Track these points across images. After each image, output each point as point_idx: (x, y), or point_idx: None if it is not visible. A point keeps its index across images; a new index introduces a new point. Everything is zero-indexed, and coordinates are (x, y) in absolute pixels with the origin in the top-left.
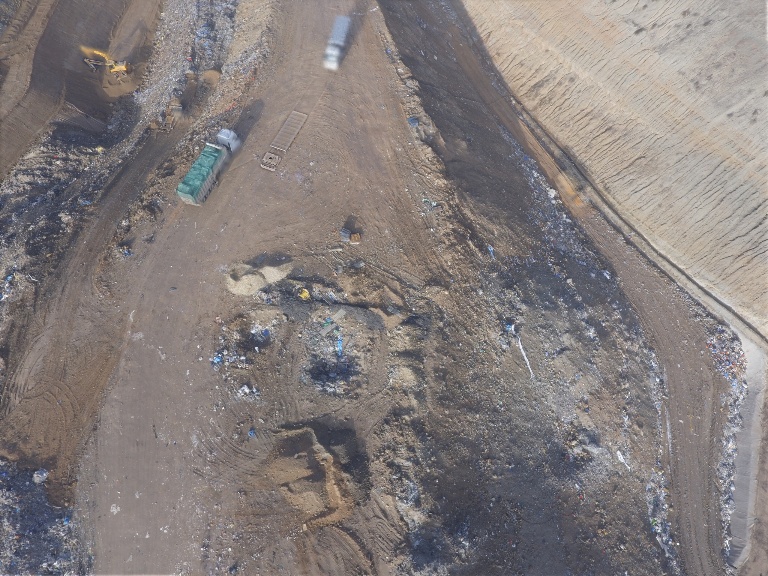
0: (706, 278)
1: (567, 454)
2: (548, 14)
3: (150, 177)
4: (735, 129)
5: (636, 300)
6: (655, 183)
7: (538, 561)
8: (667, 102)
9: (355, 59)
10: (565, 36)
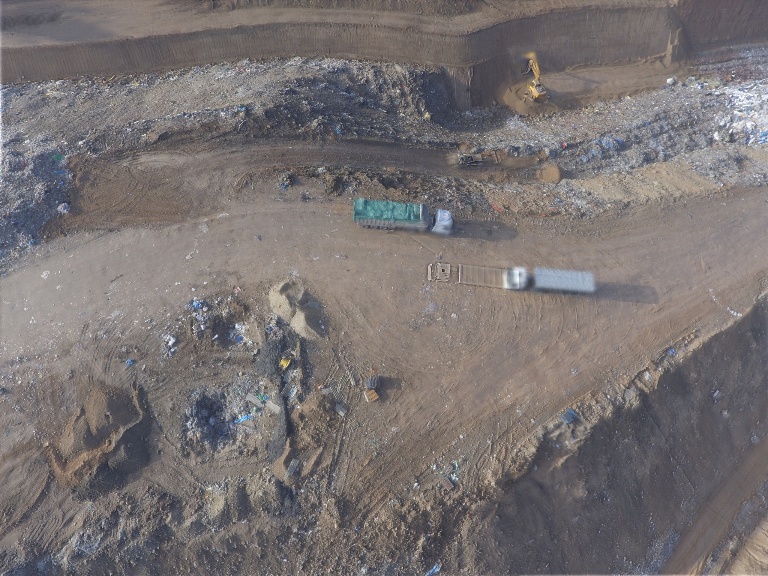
0: None
1: None
2: None
3: (390, 169)
4: None
5: None
6: None
7: None
8: None
9: (634, 314)
10: None
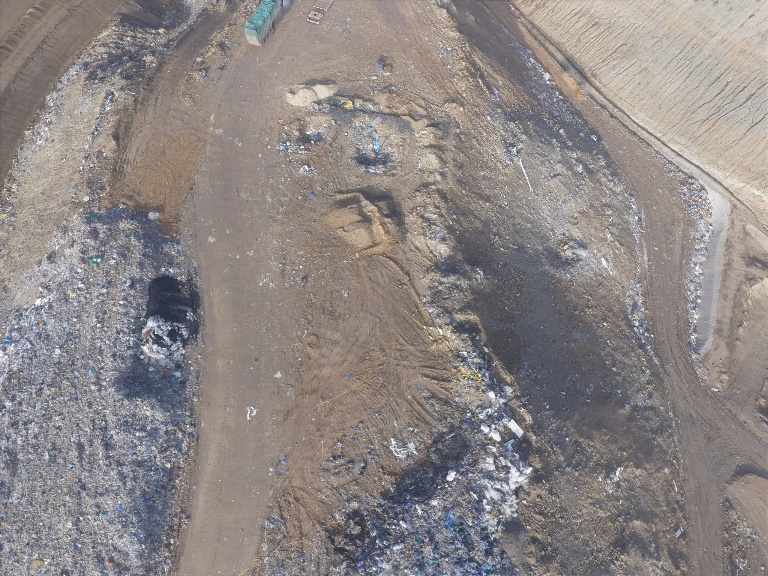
0: (678, 142)
1: (560, 256)
2: None
3: (214, 35)
4: (701, 11)
5: (619, 159)
6: (635, 65)
7: (537, 311)
8: None
9: None
10: None
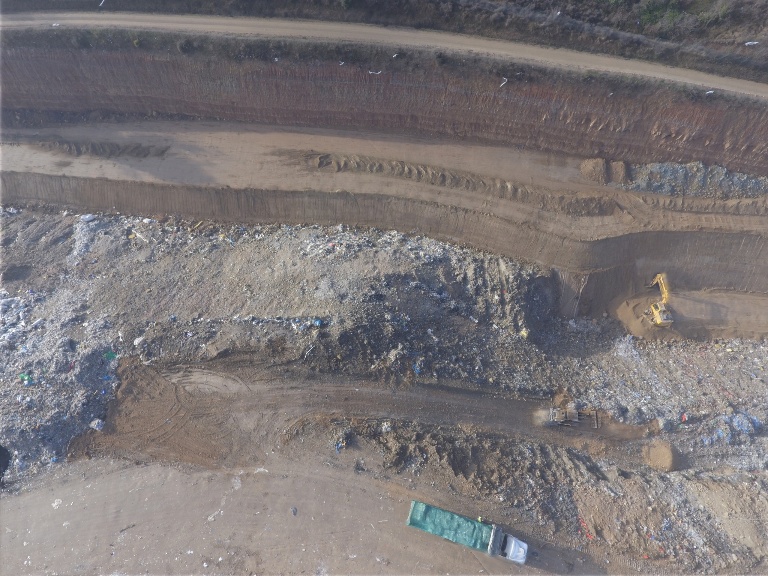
0: None
1: None
2: None
3: (465, 429)
4: None
5: None
6: None
7: None
8: None
9: None
10: None
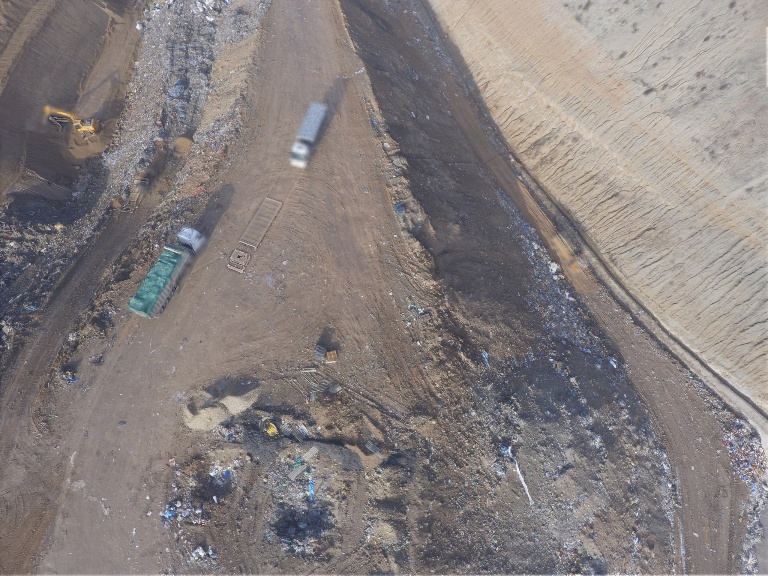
0: (722, 365)
1: None
2: (550, 68)
3: (106, 274)
4: (755, 206)
5: (645, 391)
6: (666, 258)
7: None
8: (679, 171)
9: (337, 133)
10: (568, 93)
